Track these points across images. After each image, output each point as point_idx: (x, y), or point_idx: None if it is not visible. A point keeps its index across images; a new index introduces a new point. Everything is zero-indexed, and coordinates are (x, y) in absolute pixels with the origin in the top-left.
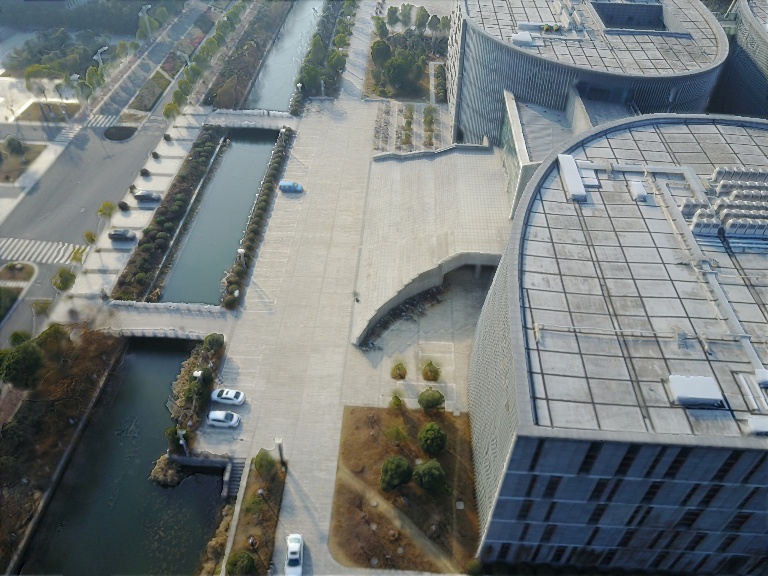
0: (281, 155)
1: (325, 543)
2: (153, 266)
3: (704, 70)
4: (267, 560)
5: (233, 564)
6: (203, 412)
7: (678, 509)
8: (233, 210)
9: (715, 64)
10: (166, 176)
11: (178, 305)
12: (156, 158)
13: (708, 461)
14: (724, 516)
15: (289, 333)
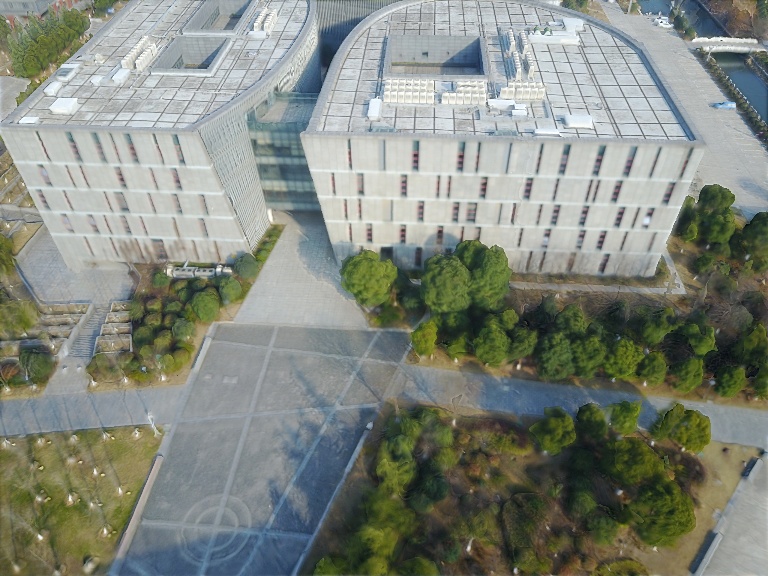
0: (761, 128)
1: (600, 2)
2: (767, 68)
3: None
4: (618, 0)
5: None
6: None
7: None
8: None
9: (397, 3)
10: None
11: None
12: None
13: None
14: None
15: (655, 42)
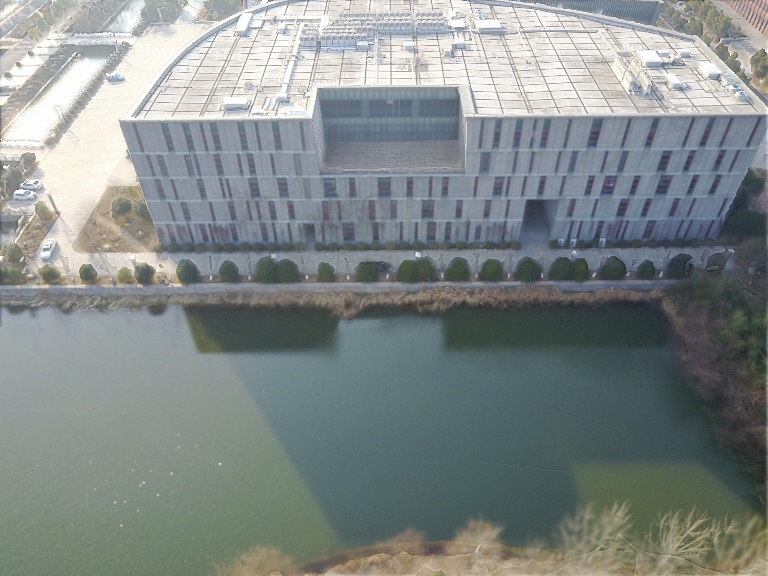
0: (114, 59)
1: (71, 244)
2: (1, 126)
3: None
4: (32, 252)
5: (5, 247)
6: None
7: (242, 179)
8: (71, 96)
9: None
10: (24, 76)
11: (10, 143)
12: (19, 66)
13: (230, 133)
14: (272, 183)
15: (85, 154)
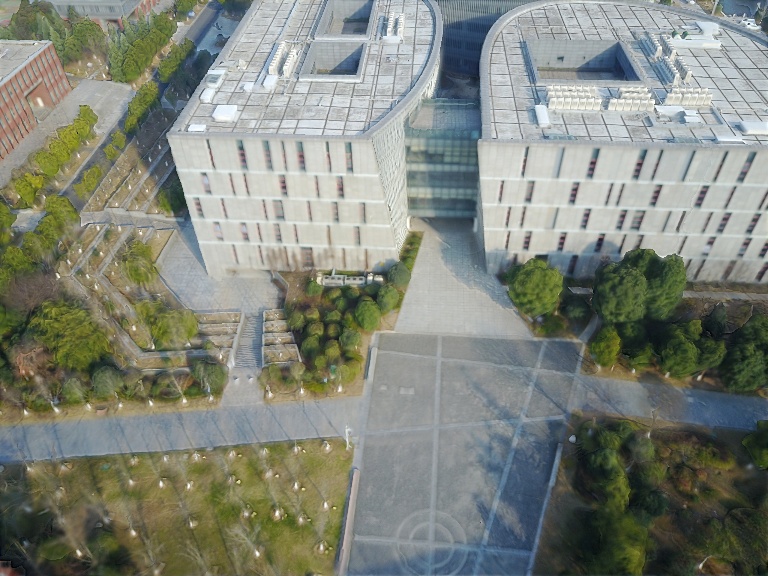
0: None
1: None
2: None
3: (534, 2)
4: None
5: None
6: (759, 24)
7: None
8: None
9: (521, 7)
10: None
11: None
12: None
13: None
14: None
15: None
